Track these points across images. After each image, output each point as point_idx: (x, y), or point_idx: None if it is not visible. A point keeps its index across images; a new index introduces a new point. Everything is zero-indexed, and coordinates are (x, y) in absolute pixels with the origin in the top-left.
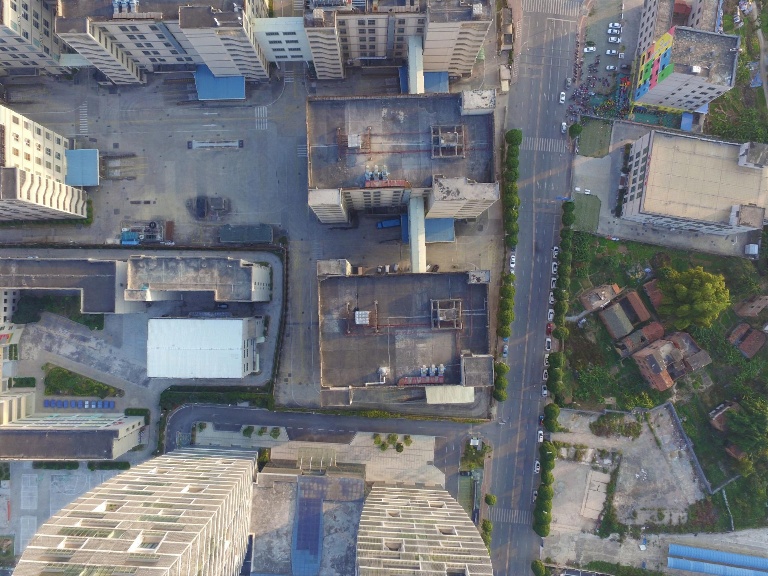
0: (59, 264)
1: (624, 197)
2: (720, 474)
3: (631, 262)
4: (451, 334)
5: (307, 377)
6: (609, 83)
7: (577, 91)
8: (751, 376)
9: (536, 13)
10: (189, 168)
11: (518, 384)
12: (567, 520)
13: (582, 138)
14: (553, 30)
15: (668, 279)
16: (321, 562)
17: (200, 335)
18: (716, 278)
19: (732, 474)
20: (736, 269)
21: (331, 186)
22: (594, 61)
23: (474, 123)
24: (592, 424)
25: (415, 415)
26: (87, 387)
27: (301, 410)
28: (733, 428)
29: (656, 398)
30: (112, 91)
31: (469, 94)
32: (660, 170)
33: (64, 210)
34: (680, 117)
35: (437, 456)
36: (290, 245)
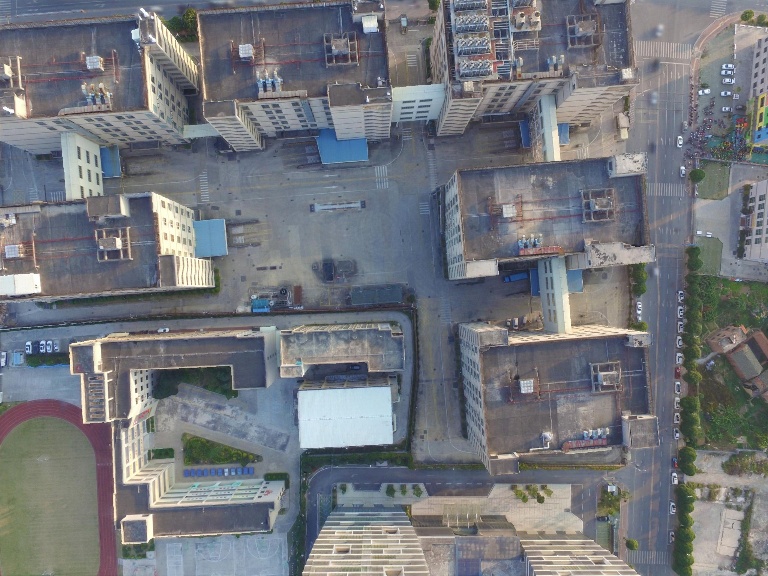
0: (207, 342)
1: (746, 238)
2: None
3: (755, 302)
4: (611, 396)
5: (442, 433)
6: (725, 125)
7: (694, 134)
8: None
9: None
10: (313, 231)
11: None
12: (704, 558)
13: (701, 181)
14: (667, 74)
15: None
16: None
17: (350, 404)
18: None
19: None
20: None
21: (484, 255)
22: (709, 103)
23: (622, 185)
24: (724, 464)
25: (551, 465)
26: (226, 455)
27: (441, 467)
28: None
29: None
30: (231, 158)
31: (621, 159)
32: None
33: (202, 285)
34: None
35: (574, 503)
36: (418, 303)
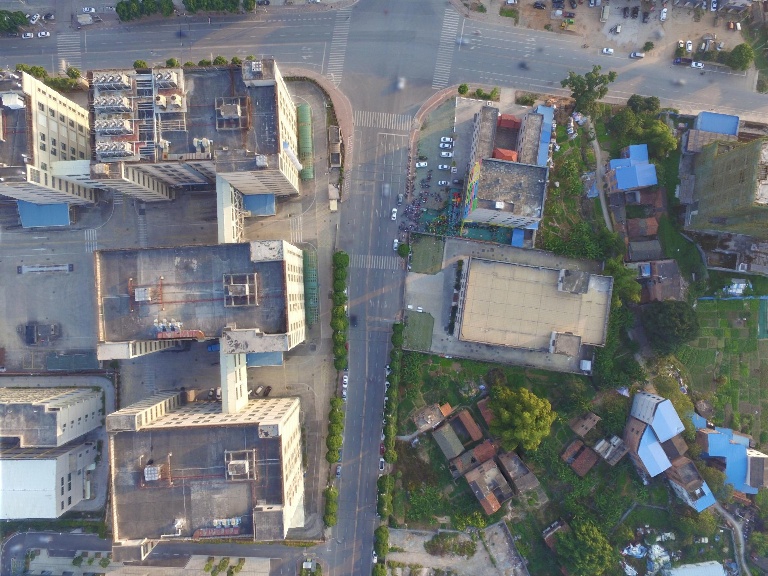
0: None
1: (456, 315)
2: None
3: (464, 380)
4: (246, 484)
5: None
6: (441, 198)
7: (409, 207)
8: (584, 494)
9: (367, 128)
10: (19, 293)
11: (352, 504)
12: None
13: (415, 255)
14: (385, 145)
15: (498, 399)
16: None
17: (13, 476)
18: (538, 403)
19: None
20: (567, 387)
21: (125, 337)
22: (426, 176)
23: (268, 270)
24: (426, 544)
25: None
26: None
27: None
28: (559, 552)
29: (490, 516)
30: None
31: (256, 245)
32: (479, 297)
33: None
34: (512, 232)
35: None
36: (122, 369)
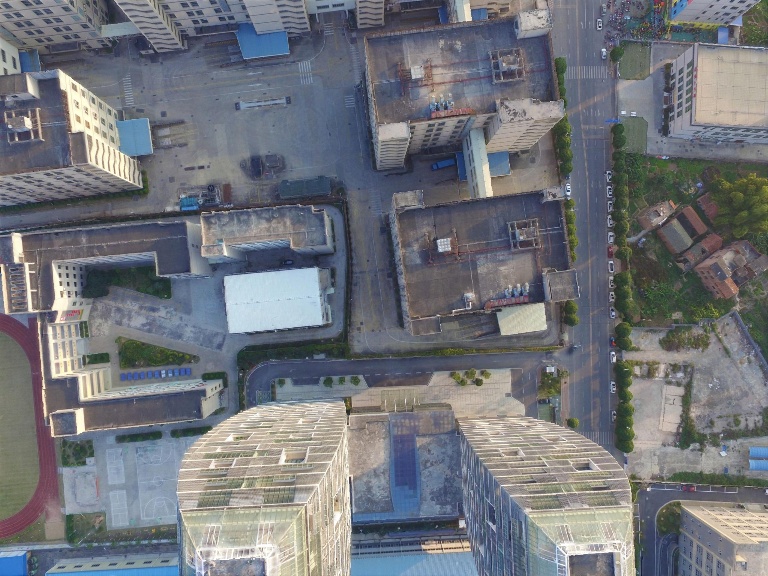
0: (129, 230)
1: (670, 115)
2: None
3: (683, 178)
4: (530, 254)
5: (379, 324)
6: (643, 6)
7: (613, 17)
8: None
9: None
10: (239, 129)
11: (586, 309)
12: (647, 436)
13: (622, 62)
14: None
15: (722, 190)
16: (421, 496)
17: (277, 287)
18: None
19: None
20: None
21: (397, 121)
22: None
23: (530, 46)
24: (662, 340)
25: (489, 349)
26: (162, 356)
27: (378, 355)
28: None
29: (721, 308)
30: (154, 60)
31: (525, 15)
32: (707, 81)
33: (125, 179)
34: (716, 32)
35: (514, 387)
36: (348, 195)
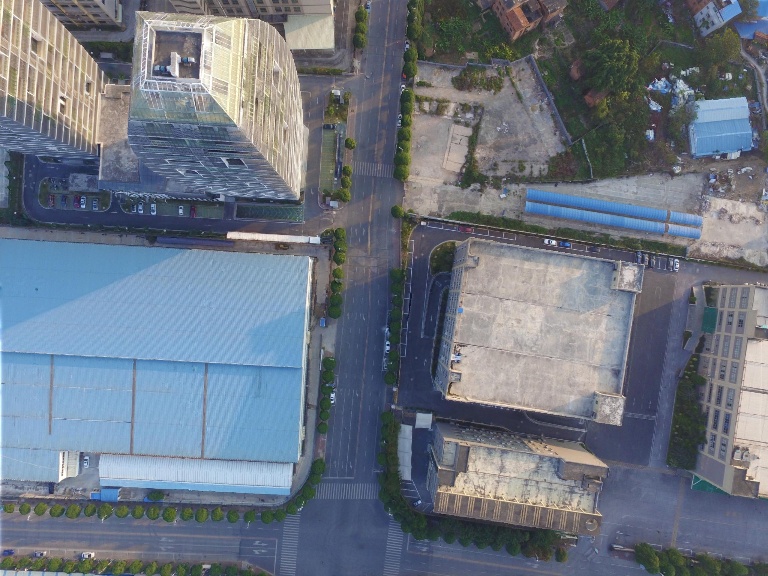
0: None
1: None
2: (580, 125)
3: None
4: None
5: None
6: None
7: None
8: (610, 27)
9: None
10: None
11: (381, 40)
12: (429, 173)
13: None
14: None
15: None
16: None
17: None
18: None
19: (592, 126)
20: None
21: None
22: None
23: None
24: (454, 78)
25: None
26: None
27: None
28: (586, 63)
29: (517, 52)
30: None
31: None
32: None
33: None
34: None
35: None
36: None
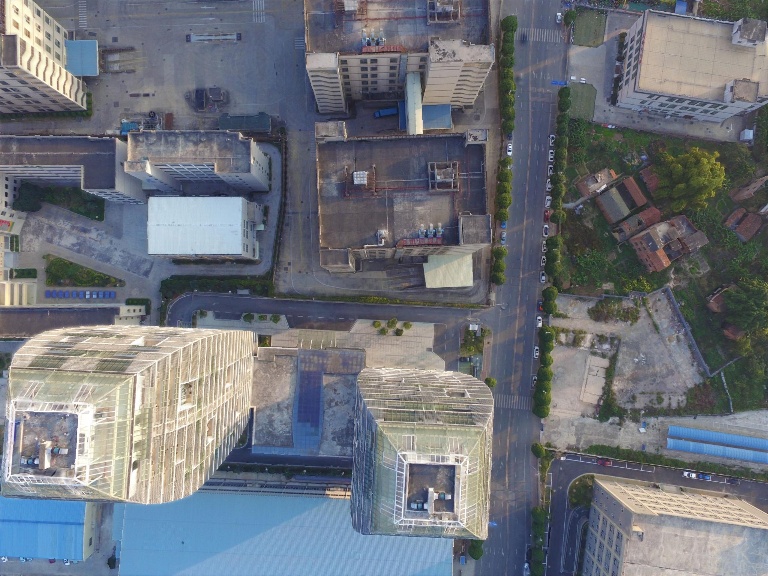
0: (59, 142)
1: (619, 84)
2: (718, 357)
3: (627, 149)
4: (449, 197)
5: (307, 266)
6: None
7: None
8: (748, 259)
9: None
10: (188, 61)
11: (516, 271)
12: (567, 405)
13: (577, 28)
14: None
15: (664, 163)
16: (322, 435)
17: (200, 212)
18: (711, 156)
19: (730, 357)
20: (731, 153)
21: None
22: None
23: None
24: (590, 309)
25: (414, 302)
26: (88, 277)
27: (301, 296)
28: (730, 306)
29: (654, 283)
30: None
31: None
32: (654, 49)
33: (64, 94)
34: (674, 6)
35: (437, 343)
36: (288, 136)
